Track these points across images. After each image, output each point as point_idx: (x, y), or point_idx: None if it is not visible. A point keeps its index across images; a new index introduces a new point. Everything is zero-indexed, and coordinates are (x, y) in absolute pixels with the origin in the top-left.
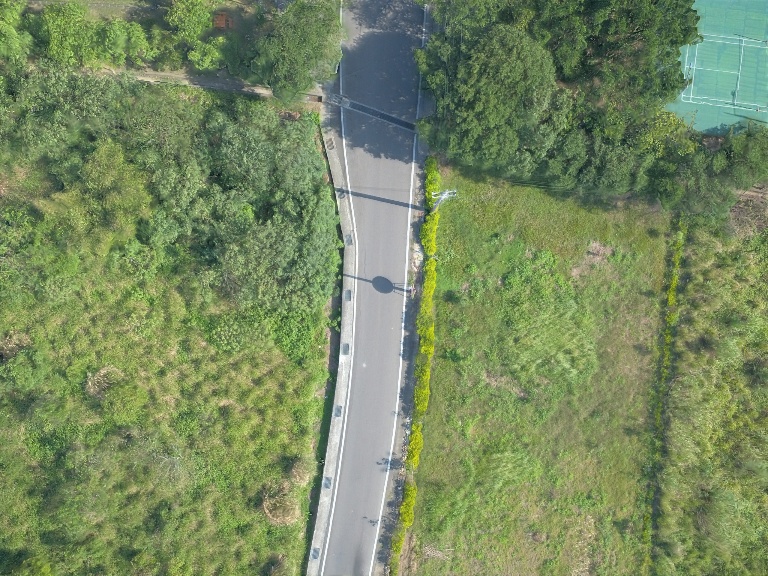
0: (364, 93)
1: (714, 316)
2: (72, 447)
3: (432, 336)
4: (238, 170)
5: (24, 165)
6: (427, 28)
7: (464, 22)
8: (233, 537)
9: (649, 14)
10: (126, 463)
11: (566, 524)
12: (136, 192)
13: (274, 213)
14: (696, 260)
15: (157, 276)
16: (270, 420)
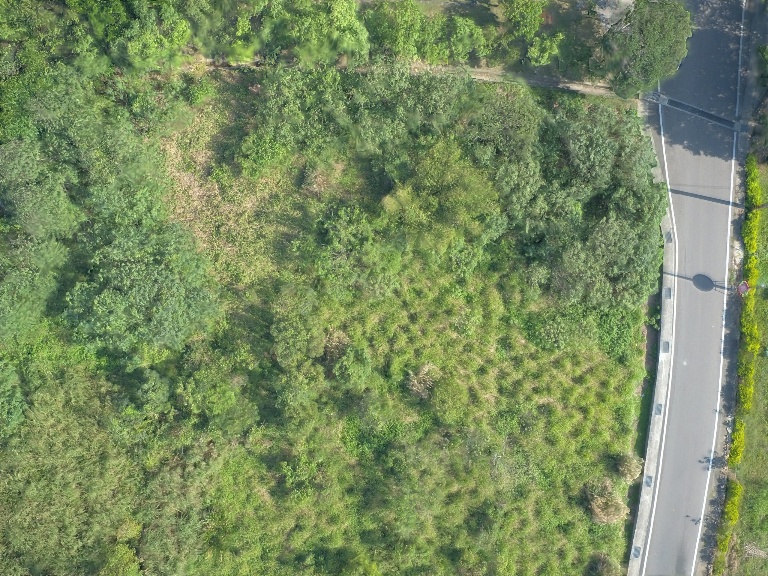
0: (682, 90)
1: None
2: (392, 445)
3: None
4: (580, 167)
5: (340, 162)
6: (745, 25)
7: None
8: (556, 536)
9: None
10: (446, 461)
11: None
12: (483, 189)
13: (609, 211)
14: None
15: (474, 274)
16: (592, 418)
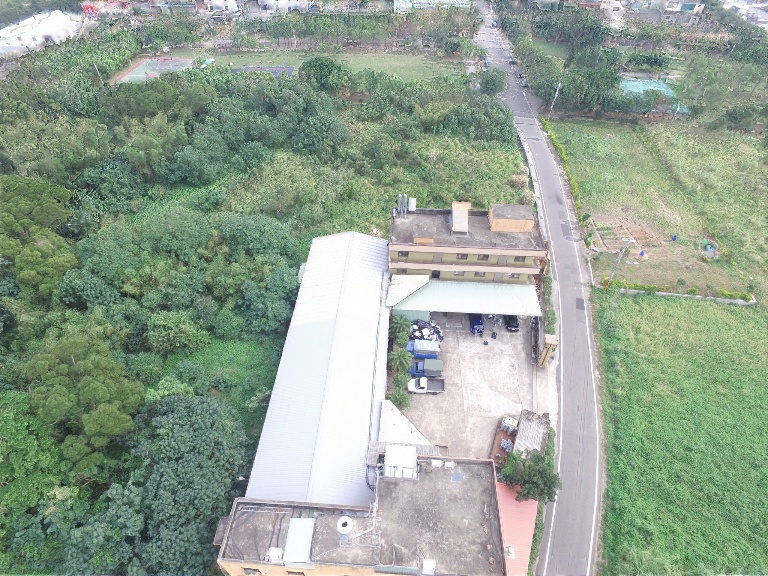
0: None
1: None
2: None
3: None
4: (480, 105)
5: None
6: None
7: None
8: None
9: None
10: None
11: None
12: None
13: None
14: None
15: None
16: None
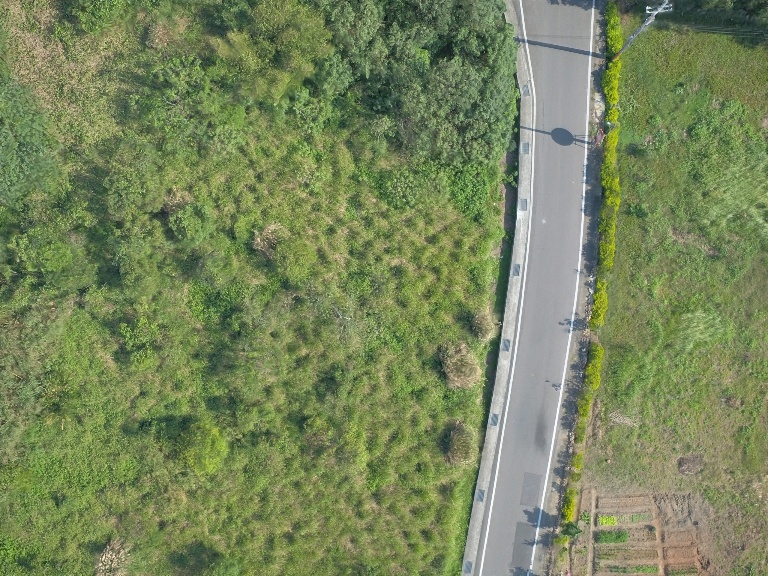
0: None
1: None
2: (238, 309)
3: (618, 187)
4: (420, 8)
5: (186, 19)
6: None
7: None
8: (408, 402)
9: None
10: (294, 325)
11: (762, 388)
12: (316, 29)
13: (455, 55)
14: None
15: (324, 132)
16: (446, 279)
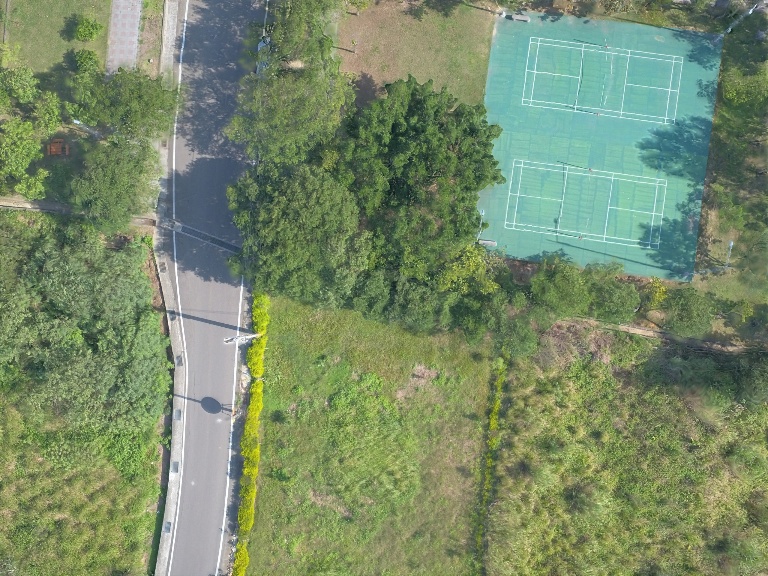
0: (196, 218)
1: (534, 441)
2: None
3: (255, 458)
4: None
5: None
6: None
7: (277, 160)
8: None
9: (445, 160)
10: None
11: None
12: None
13: (99, 340)
14: (517, 385)
15: None
16: (101, 535)
